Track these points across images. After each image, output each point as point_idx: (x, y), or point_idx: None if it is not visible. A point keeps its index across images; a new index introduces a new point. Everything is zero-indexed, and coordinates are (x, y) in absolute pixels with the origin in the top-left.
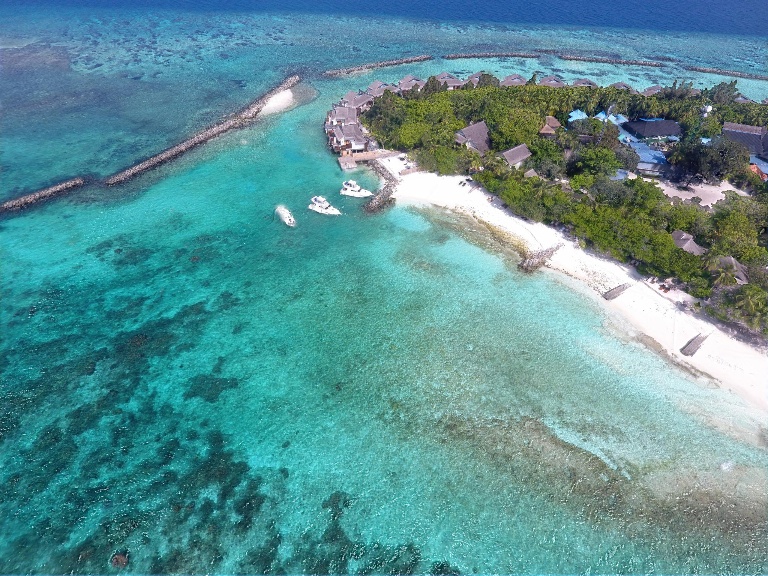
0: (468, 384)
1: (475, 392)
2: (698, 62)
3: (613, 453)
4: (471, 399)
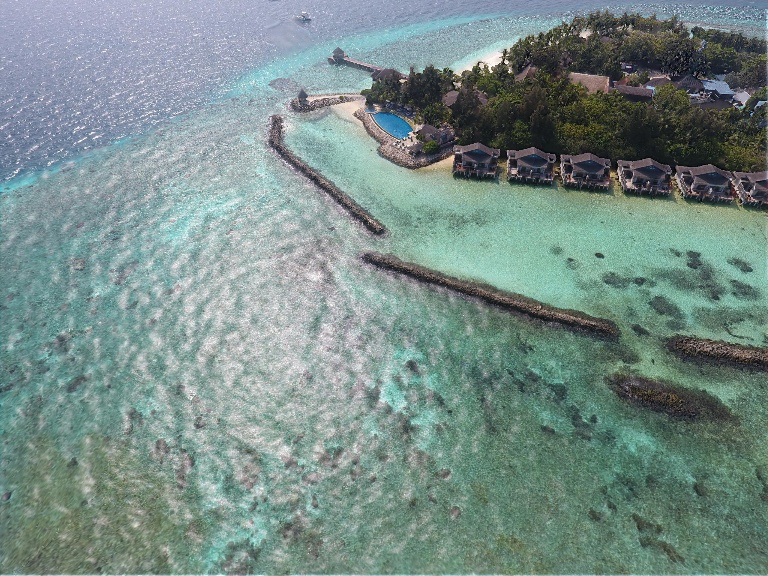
0: (764, 35)
1: (760, 34)
2: (563, 383)
3: (707, 27)
4: (760, 33)
